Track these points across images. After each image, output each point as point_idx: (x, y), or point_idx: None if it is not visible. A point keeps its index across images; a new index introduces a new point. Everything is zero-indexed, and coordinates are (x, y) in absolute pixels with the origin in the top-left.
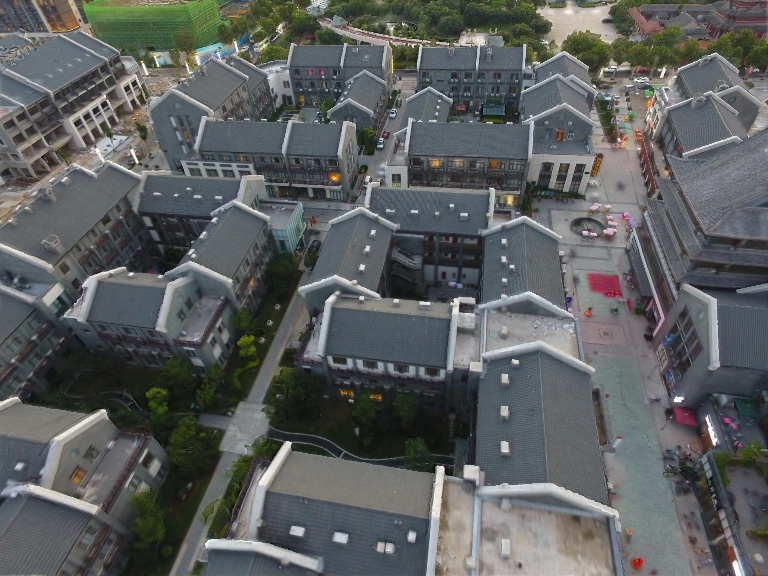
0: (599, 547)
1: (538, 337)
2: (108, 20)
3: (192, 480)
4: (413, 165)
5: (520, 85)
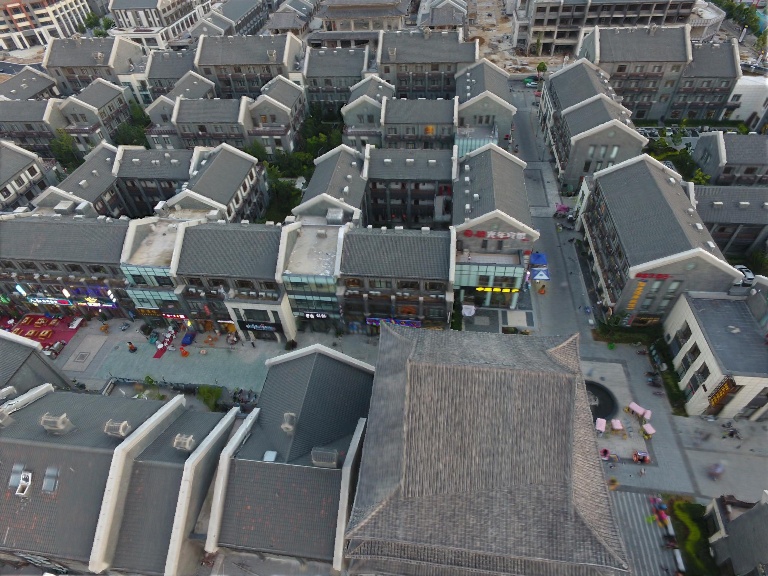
0: (160, 265)
1: (317, 254)
2: None
3: (281, 171)
4: (596, 195)
5: None
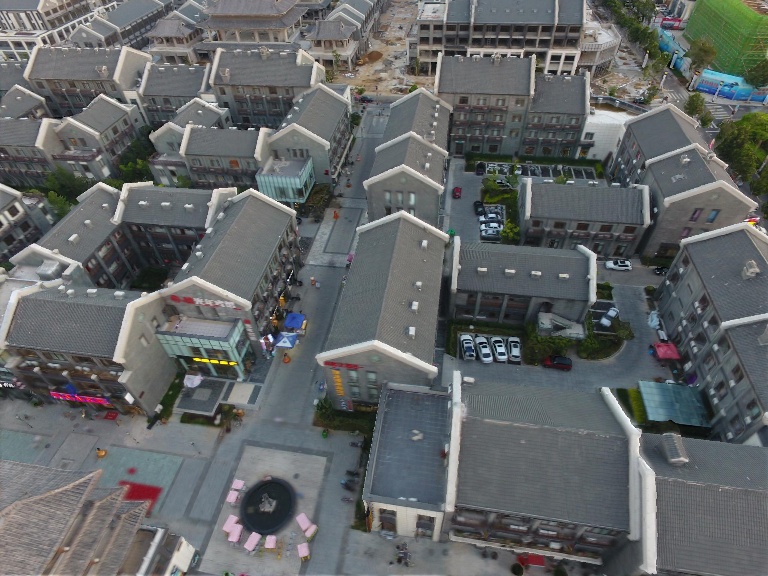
0: None
1: None
2: (708, 1)
3: None
4: None
5: (747, 434)
